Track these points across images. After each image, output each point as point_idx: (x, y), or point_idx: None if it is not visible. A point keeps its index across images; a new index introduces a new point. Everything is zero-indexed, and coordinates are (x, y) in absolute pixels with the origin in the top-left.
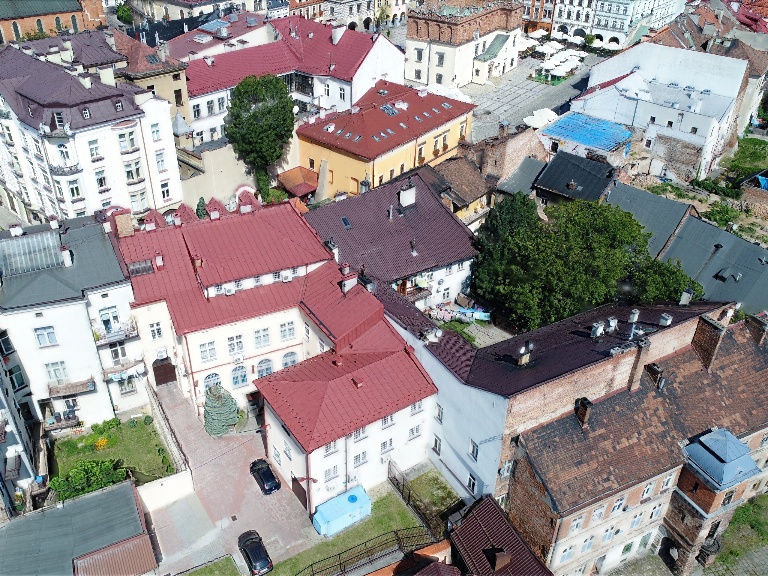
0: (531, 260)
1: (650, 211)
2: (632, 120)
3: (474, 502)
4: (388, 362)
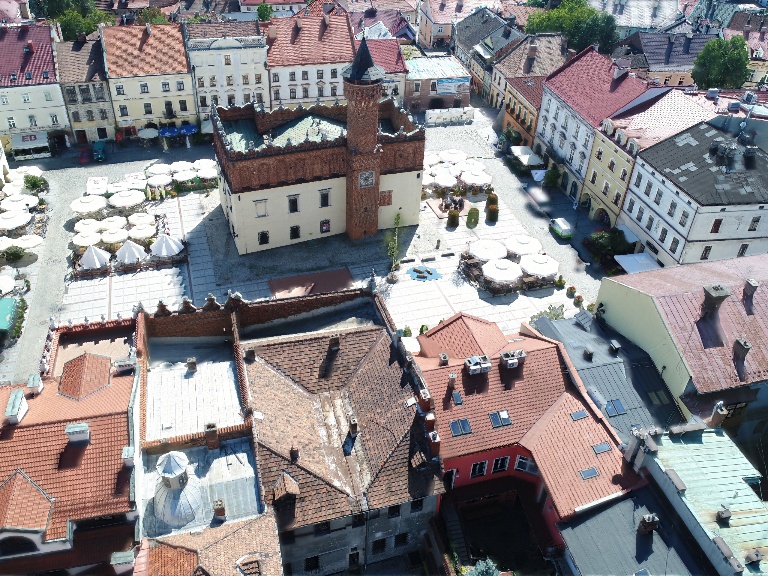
0: None
1: None
2: None
3: None
4: None
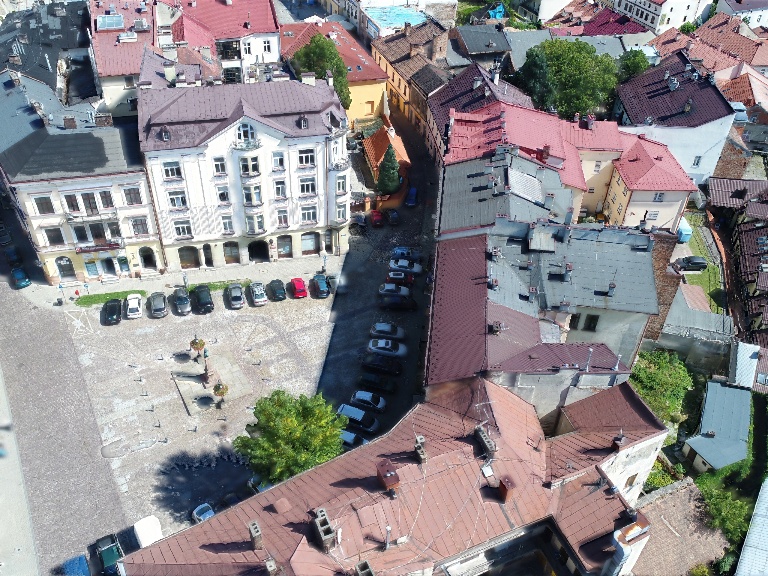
0: (582, 80)
1: (535, 42)
2: (407, 0)
3: (700, 189)
4: (646, 146)
